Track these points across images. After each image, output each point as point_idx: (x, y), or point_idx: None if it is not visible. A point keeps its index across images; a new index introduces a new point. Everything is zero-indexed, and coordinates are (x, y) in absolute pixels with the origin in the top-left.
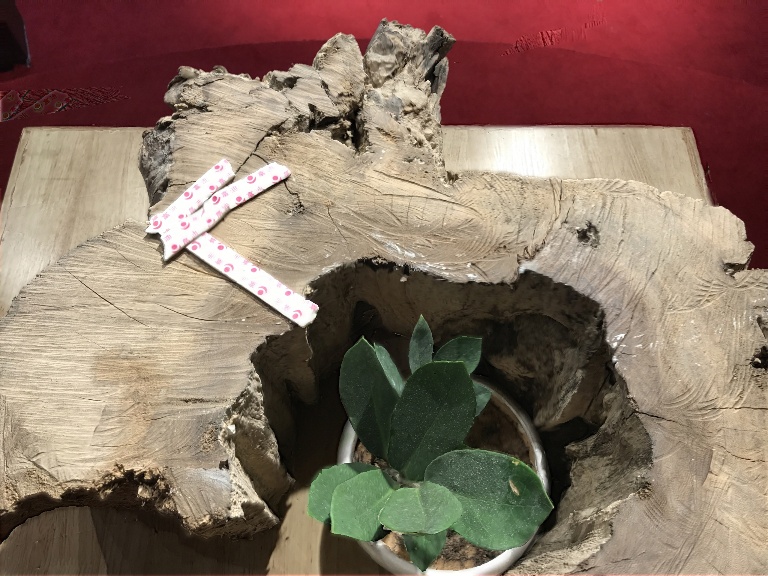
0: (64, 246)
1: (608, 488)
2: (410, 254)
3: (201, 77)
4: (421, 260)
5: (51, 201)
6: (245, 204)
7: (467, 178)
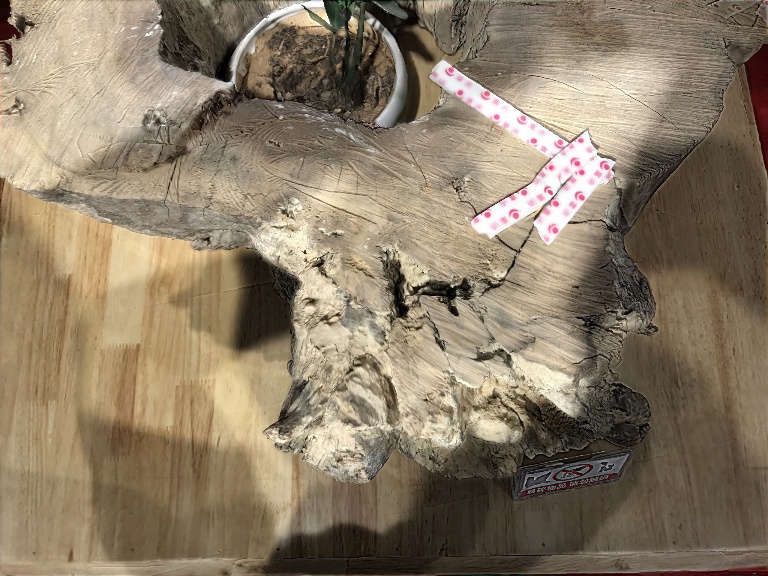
0: (725, 374)
1: (185, 1)
2: (340, 131)
3: (606, 415)
4: (329, 125)
5: (763, 435)
6: (517, 191)
7: (272, 207)
